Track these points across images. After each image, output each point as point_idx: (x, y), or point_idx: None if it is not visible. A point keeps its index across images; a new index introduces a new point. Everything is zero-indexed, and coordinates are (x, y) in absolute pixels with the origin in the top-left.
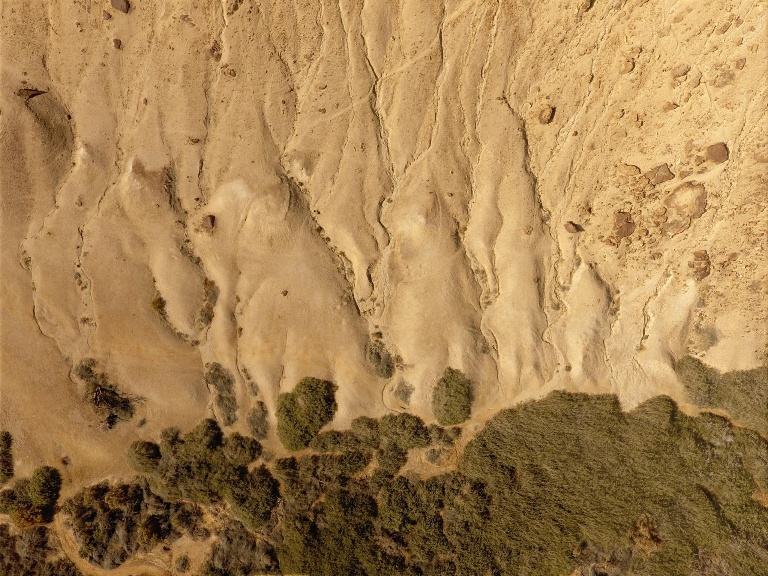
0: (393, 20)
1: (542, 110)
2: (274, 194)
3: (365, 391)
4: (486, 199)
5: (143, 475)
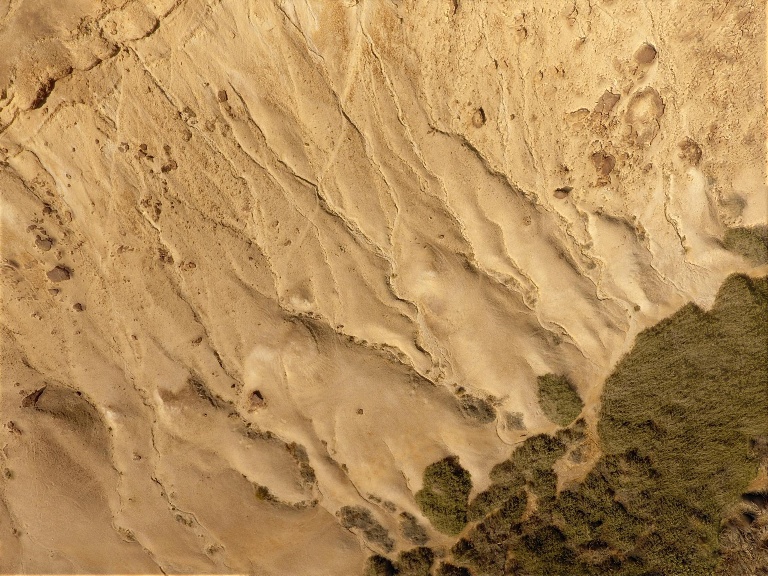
0: (297, 131)
1: (472, 117)
2: (296, 339)
3: (483, 444)
4: (474, 220)
5: None
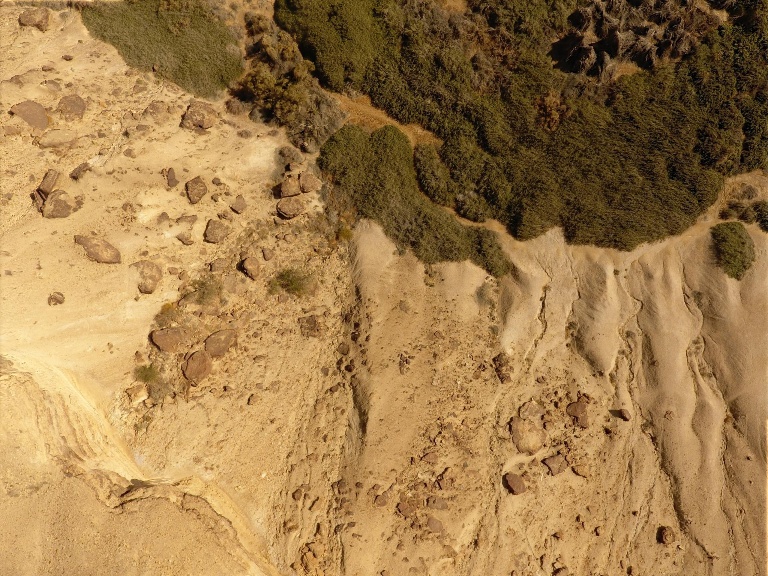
0: None
1: None
2: None
3: None
4: (713, 451)
5: None
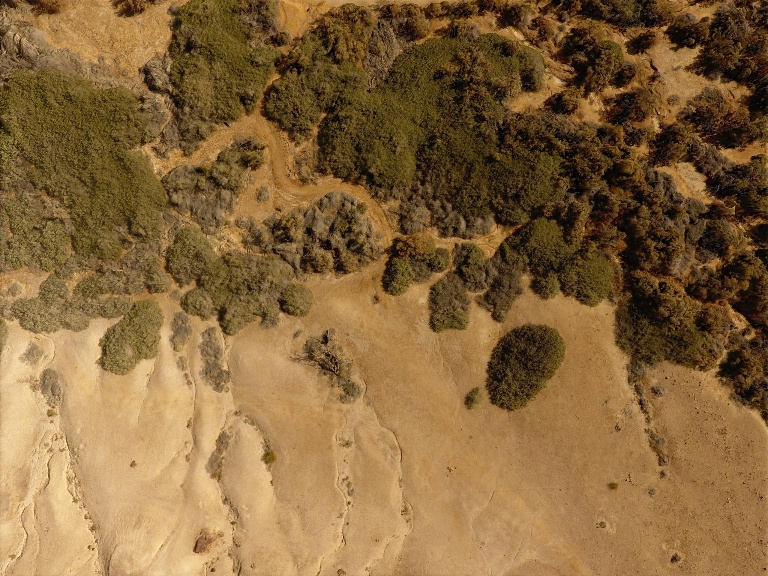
0: None
1: None
2: (123, 574)
3: (69, 358)
4: None
5: (300, 282)
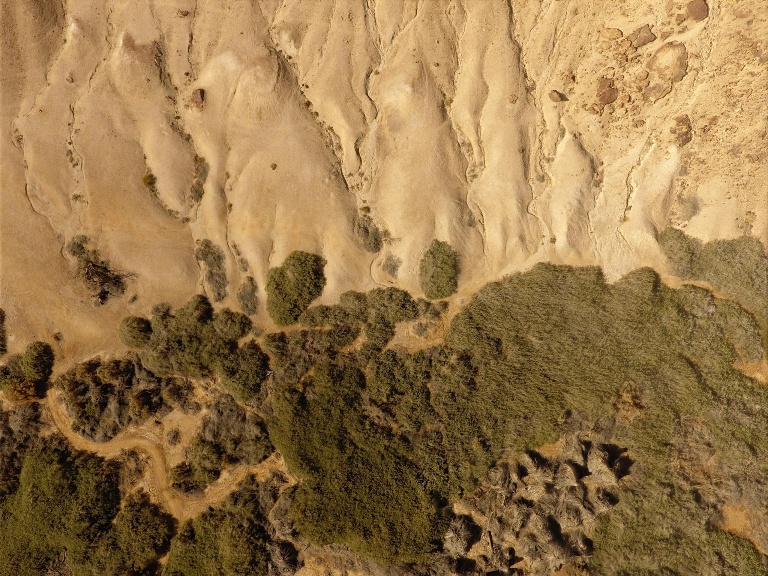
0: None
1: None
2: (263, 65)
3: (353, 265)
4: (472, 68)
5: (135, 351)
